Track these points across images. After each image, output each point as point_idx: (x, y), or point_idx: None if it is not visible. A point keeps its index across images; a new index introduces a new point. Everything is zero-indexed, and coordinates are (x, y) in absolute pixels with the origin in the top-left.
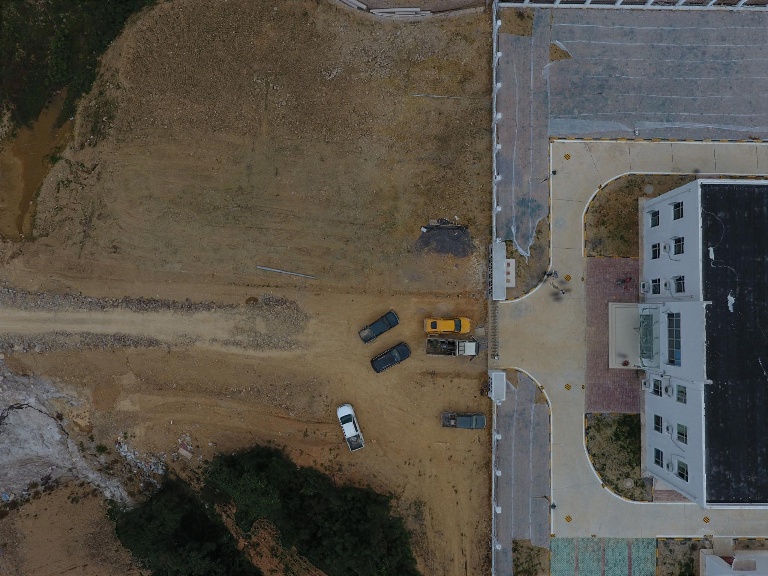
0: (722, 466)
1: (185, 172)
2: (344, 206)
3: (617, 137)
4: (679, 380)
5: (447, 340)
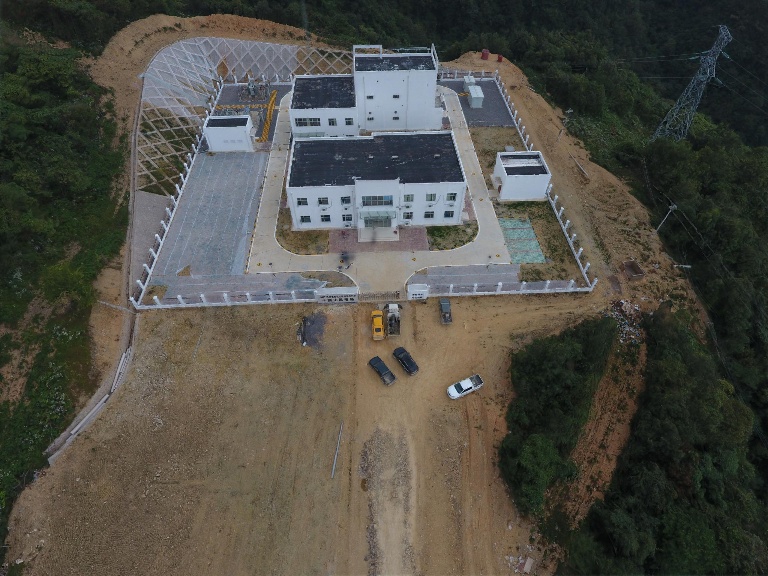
0: (444, 179)
1: (228, 568)
2: (280, 404)
3: (250, 241)
4: (401, 199)
5: (388, 322)
